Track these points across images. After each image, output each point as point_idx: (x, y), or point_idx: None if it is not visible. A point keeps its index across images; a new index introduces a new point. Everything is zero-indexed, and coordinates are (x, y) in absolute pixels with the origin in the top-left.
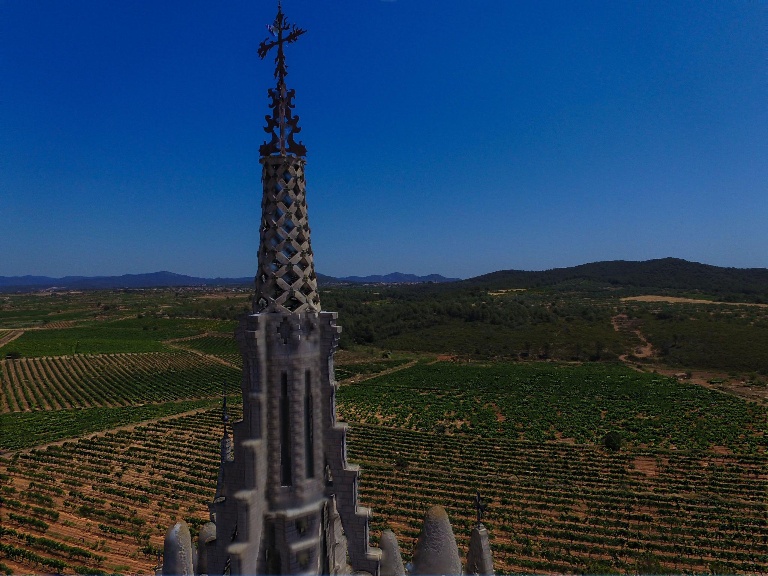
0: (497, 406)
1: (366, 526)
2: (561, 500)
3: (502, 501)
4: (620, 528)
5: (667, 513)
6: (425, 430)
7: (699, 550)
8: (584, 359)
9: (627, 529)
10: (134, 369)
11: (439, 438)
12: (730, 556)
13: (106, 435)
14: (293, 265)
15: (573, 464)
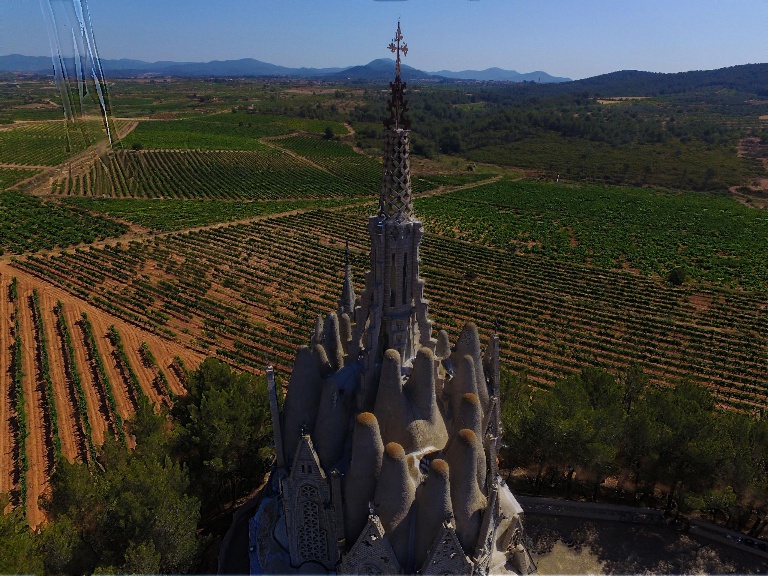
0: (573, 231)
1: None
2: (604, 320)
3: (552, 315)
4: (649, 347)
5: (698, 342)
6: (497, 247)
7: (710, 371)
8: (685, 188)
9: (655, 349)
10: (238, 166)
11: (509, 256)
12: (735, 379)
13: (229, 226)
14: (401, 198)
15: (629, 292)
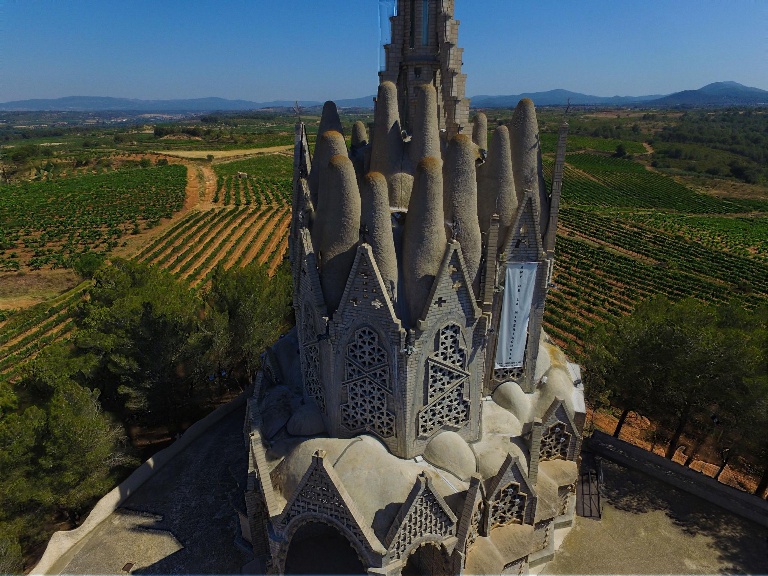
0: None
1: (453, 79)
2: None
3: None
4: None
5: None
6: None
7: None
8: None
9: None
10: None
11: None
12: None
13: None
14: None
15: None
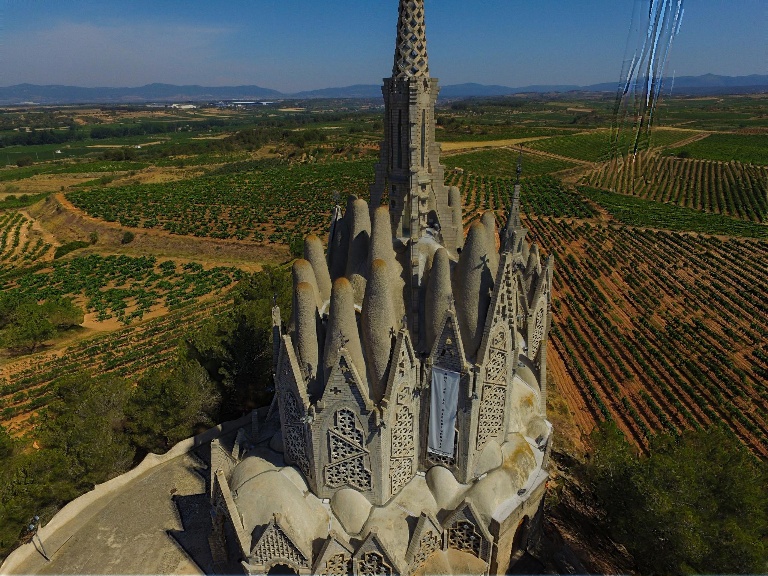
0: None
1: (412, 201)
2: None
3: None
4: None
5: None
6: None
7: None
8: None
9: None
10: None
11: None
12: None
13: (698, 236)
14: (400, 49)
15: None
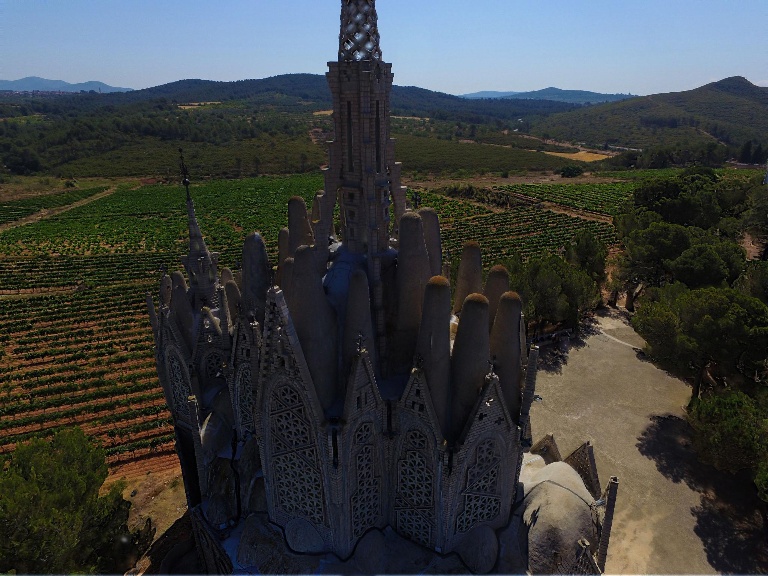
0: (230, 219)
1: None
2: None
3: None
4: None
5: None
6: (167, 250)
7: None
8: None
9: None
10: None
11: None
12: None
13: None
14: None
15: None
